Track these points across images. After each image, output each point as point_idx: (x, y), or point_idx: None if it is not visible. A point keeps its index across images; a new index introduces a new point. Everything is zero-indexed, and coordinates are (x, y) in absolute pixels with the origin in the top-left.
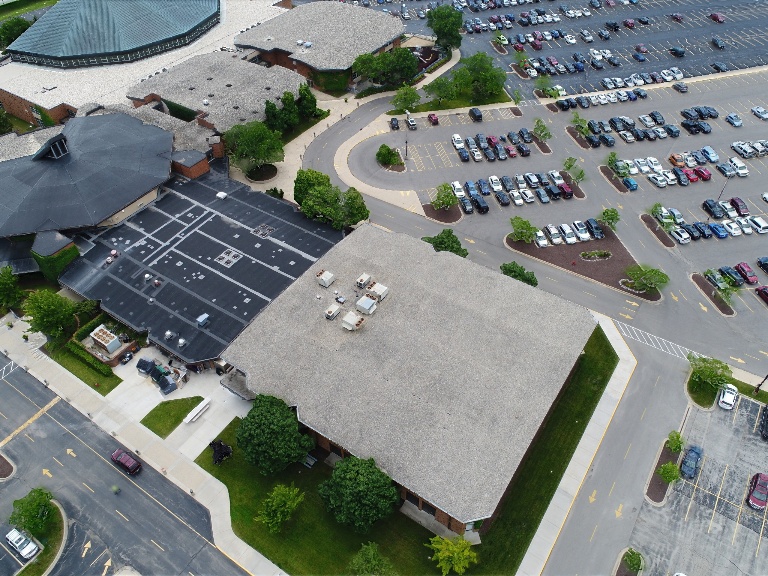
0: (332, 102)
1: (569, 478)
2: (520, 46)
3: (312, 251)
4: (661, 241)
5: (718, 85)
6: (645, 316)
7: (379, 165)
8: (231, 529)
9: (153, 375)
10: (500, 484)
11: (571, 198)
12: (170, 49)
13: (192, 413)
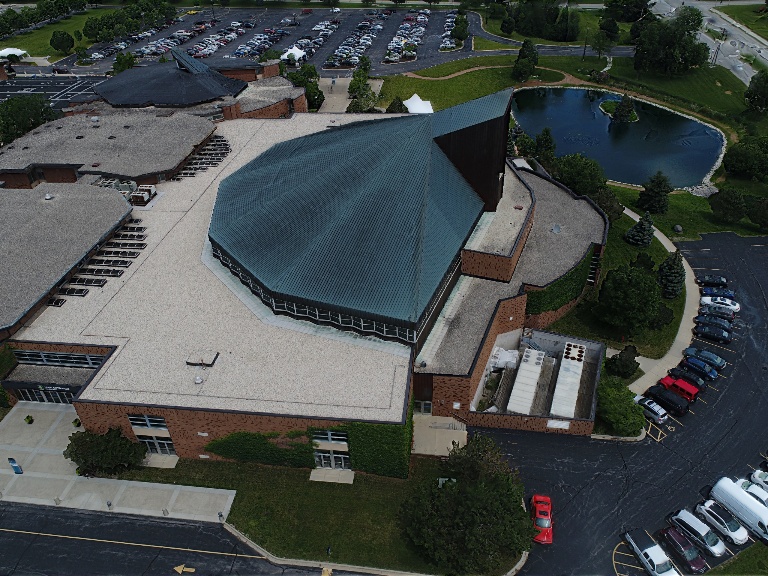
0: None
1: None
2: None
3: None
4: None
5: None
6: None
7: None
8: None
9: None
10: None
11: None
12: None
13: None
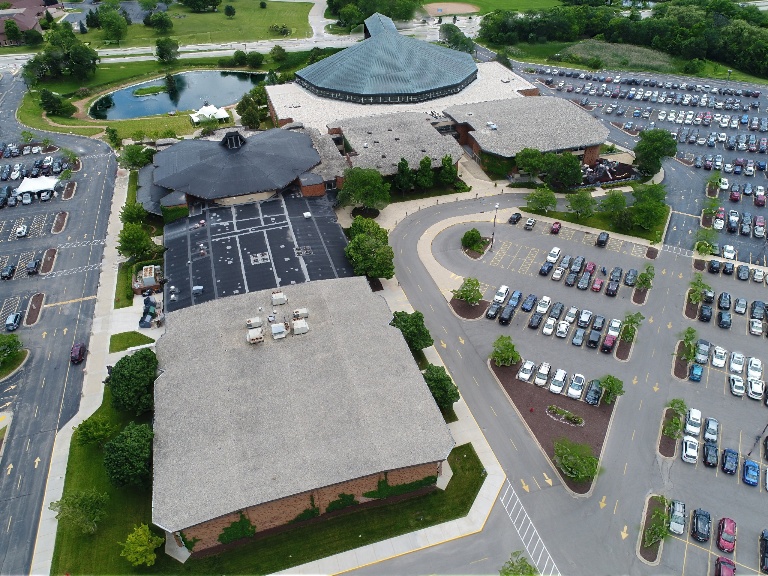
0: (483, 182)
1: (296, 572)
2: (735, 195)
3: None
4: (660, 444)
5: None
6: (545, 498)
7: (462, 246)
8: (74, 431)
9: (144, 310)
10: (203, 515)
11: (609, 354)
12: (399, 102)
13: (136, 347)
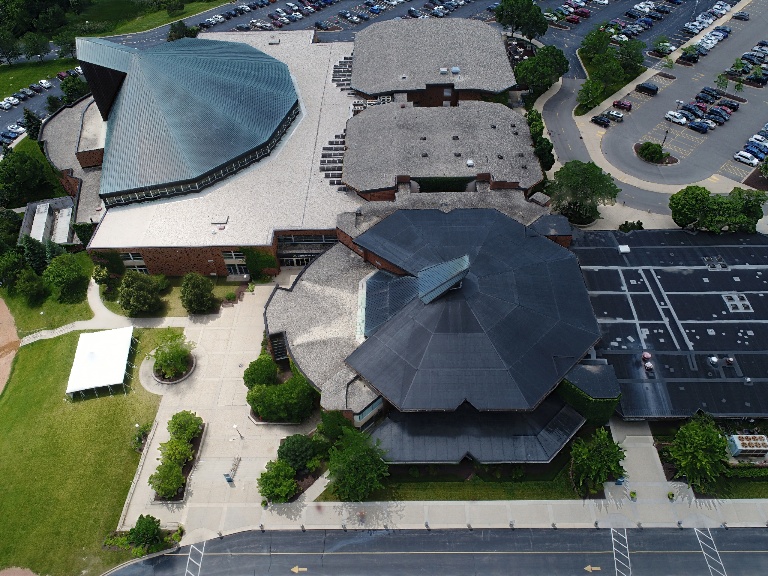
0: None
1: None
2: (576, 18)
3: None
4: None
5: (760, 7)
6: None
7: (651, 164)
8: None
9: None
10: None
11: None
12: (289, 124)
13: None
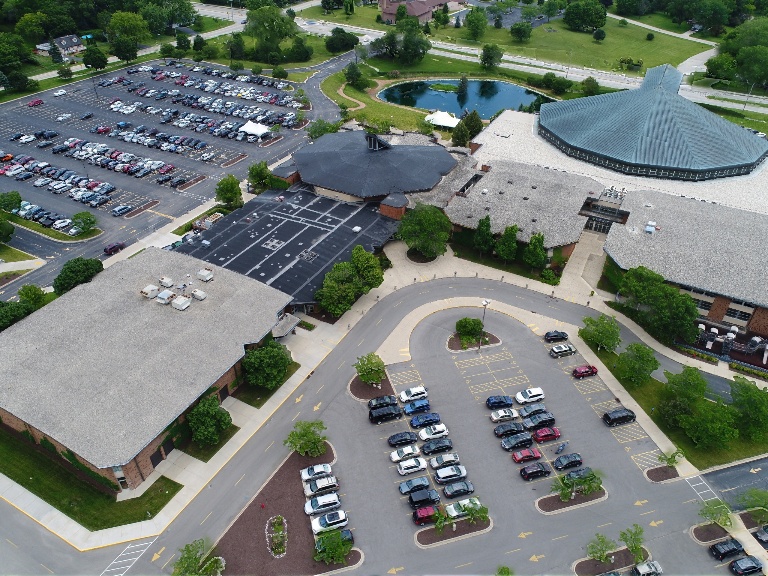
0: (584, 284)
1: None
2: None
3: (278, 283)
4: None
5: None
6: None
7: None
8: None
9: None
10: None
11: (416, 524)
12: (607, 167)
13: None
